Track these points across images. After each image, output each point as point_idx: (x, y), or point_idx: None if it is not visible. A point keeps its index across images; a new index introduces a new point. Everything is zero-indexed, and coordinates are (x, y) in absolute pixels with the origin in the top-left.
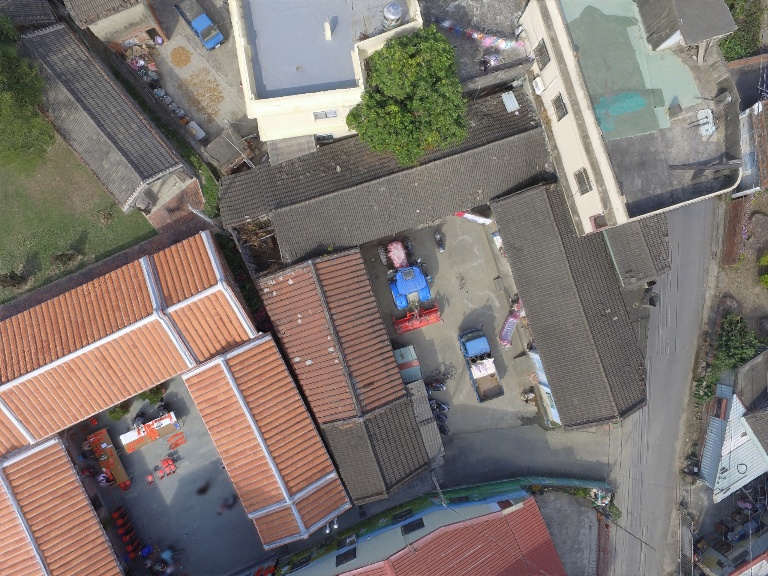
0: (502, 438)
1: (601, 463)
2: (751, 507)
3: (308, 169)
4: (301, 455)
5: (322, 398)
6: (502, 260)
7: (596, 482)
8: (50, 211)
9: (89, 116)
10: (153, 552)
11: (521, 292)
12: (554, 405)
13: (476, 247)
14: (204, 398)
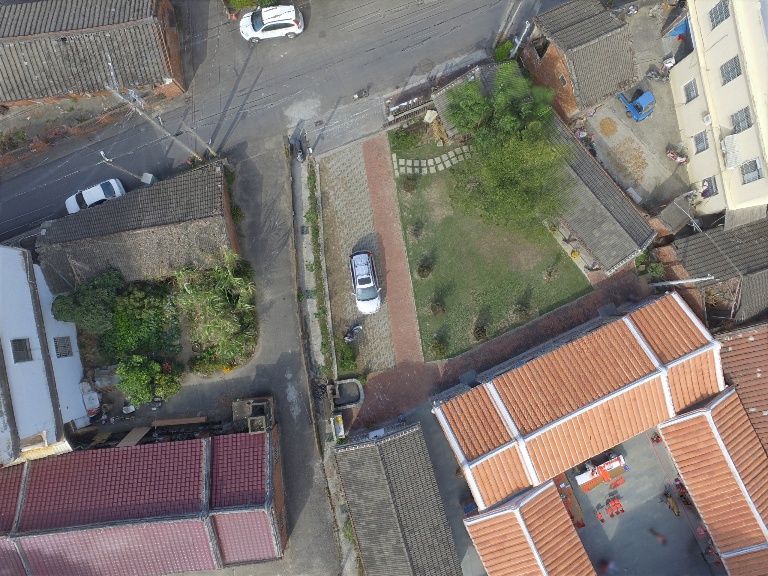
0: None
1: None
2: None
3: (759, 234)
4: None
5: None
6: None
7: None
8: (499, 269)
9: (591, 191)
10: None
11: None
12: None
13: None
14: (680, 446)
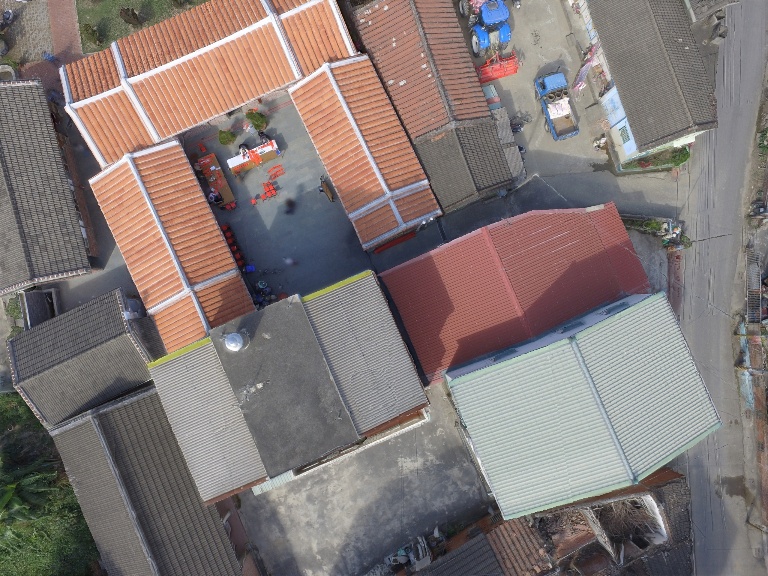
0: (575, 182)
1: (670, 206)
2: None
3: None
4: (397, 160)
5: (415, 114)
6: (574, 16)
7: None
8: None
9: None
10: (255, 272)
11: (597, 24)
12: (628, 133)
13: (549, 7)
14: (309, 108)
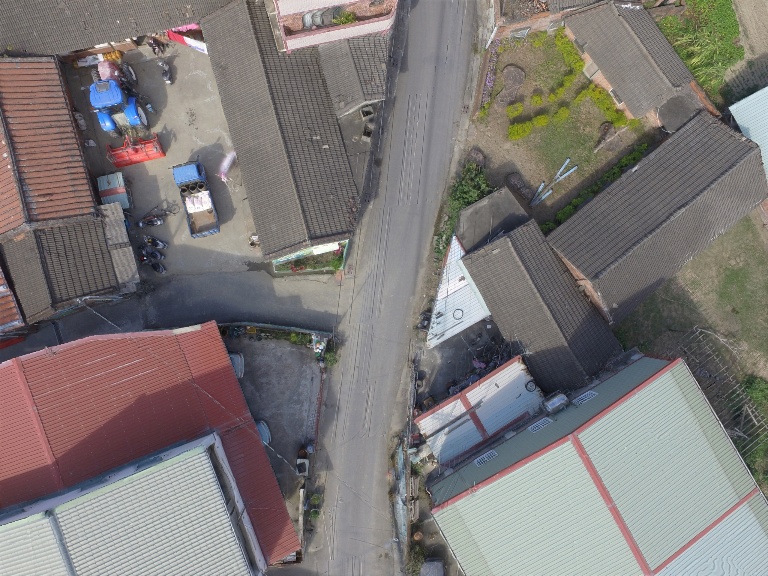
0: (225, 282)
1: (329, 314)
2: (484, 366)
3: None
4: None
5: None
6: None
7: (320, 331)
8: None
9: None
10: None
11: (227, 114)
12: None
13: (210, 83)
14: None
